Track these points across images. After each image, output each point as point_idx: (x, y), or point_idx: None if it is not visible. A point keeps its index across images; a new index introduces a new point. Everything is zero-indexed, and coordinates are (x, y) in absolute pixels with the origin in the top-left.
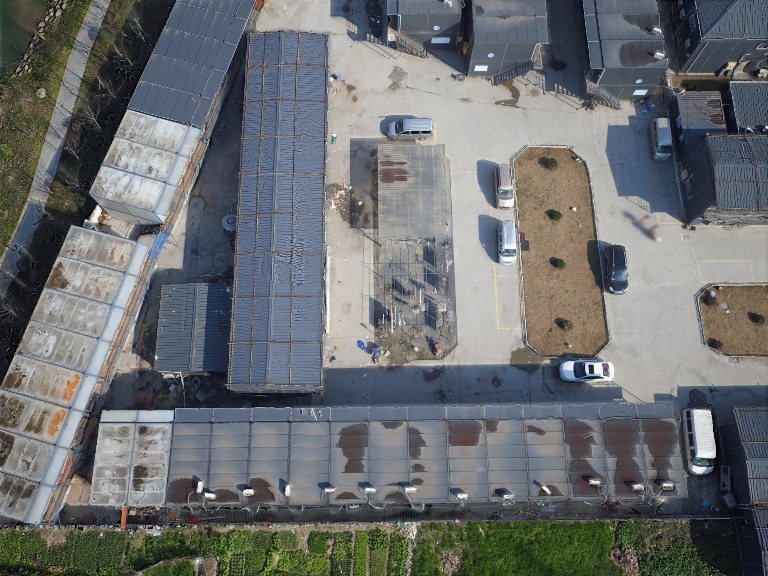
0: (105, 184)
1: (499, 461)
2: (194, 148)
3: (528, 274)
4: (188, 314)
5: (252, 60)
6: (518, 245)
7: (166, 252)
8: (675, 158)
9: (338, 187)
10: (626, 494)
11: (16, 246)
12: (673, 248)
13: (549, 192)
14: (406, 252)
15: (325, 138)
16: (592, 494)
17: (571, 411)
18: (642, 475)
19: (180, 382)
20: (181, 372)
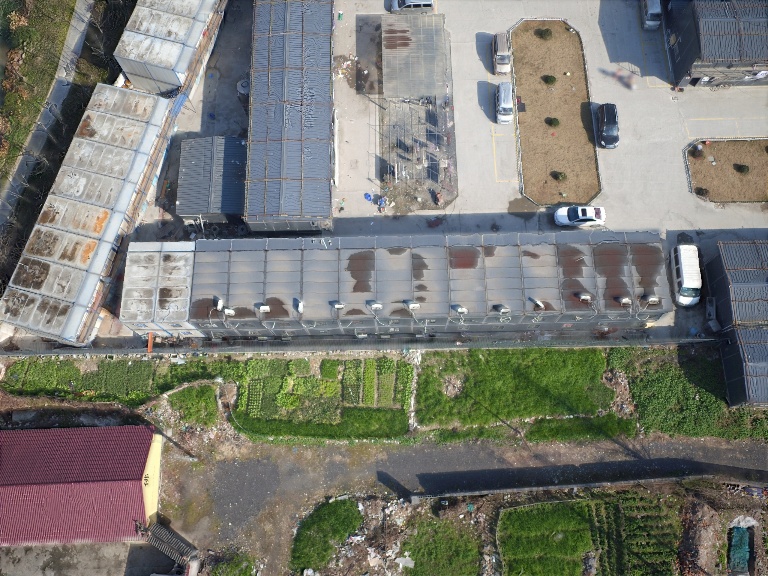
0: (128, 46)
1: (496, 281)
2: (210, 17)
3: (524, 133)
4: (206, 164)
5: None
6: (515, 107)
7: (185, 117)
8: (664, 28)
9: (345, 58)
10: (615, 308)
11: (47, 103)
12: (662, 108)
13: (544, 60)
14: (409, 115)
15: (332, 3)
16: (583, 308)
17: (563, 237)
18: (630, 292)
19: (200, 230)
20: (201, 215)
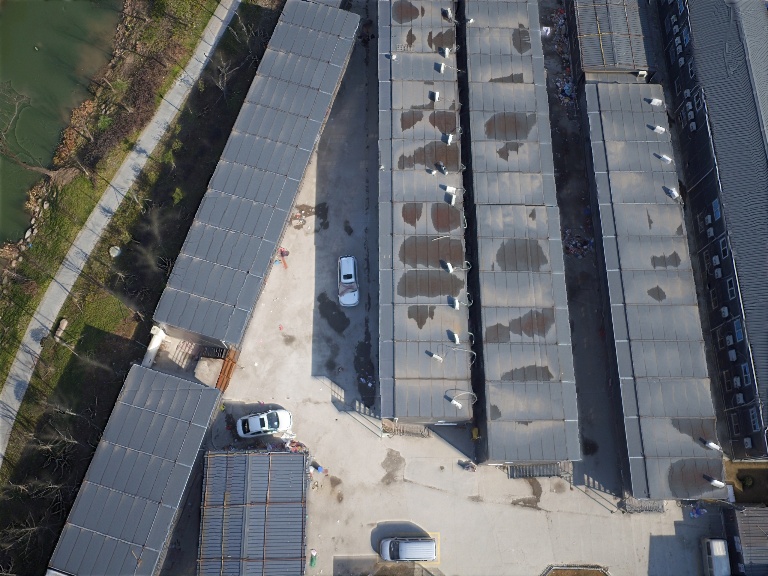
0: None
1: None
2: None
3: None
4: None
5: (210, 493)
6: None
7: None
8: None
9: None
10: None
11: None
12: None
13: None
14: None
15: None
16: None
17: None
18: None
19: None
20: None
